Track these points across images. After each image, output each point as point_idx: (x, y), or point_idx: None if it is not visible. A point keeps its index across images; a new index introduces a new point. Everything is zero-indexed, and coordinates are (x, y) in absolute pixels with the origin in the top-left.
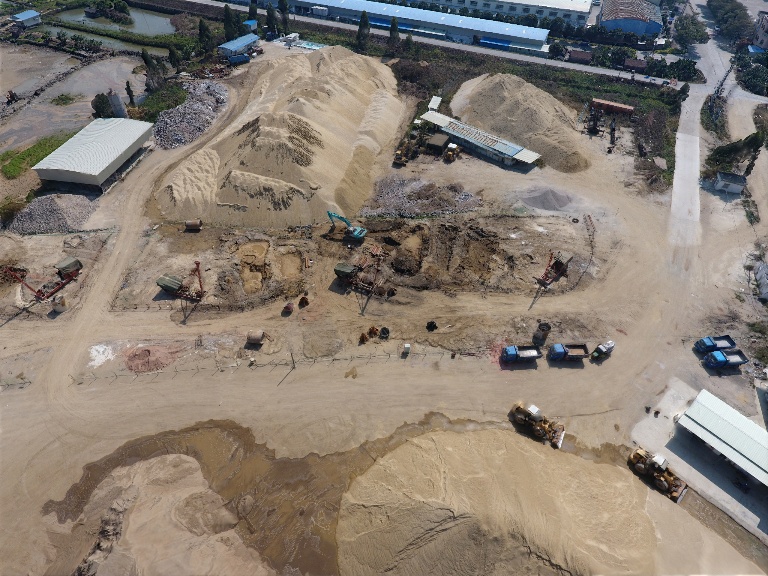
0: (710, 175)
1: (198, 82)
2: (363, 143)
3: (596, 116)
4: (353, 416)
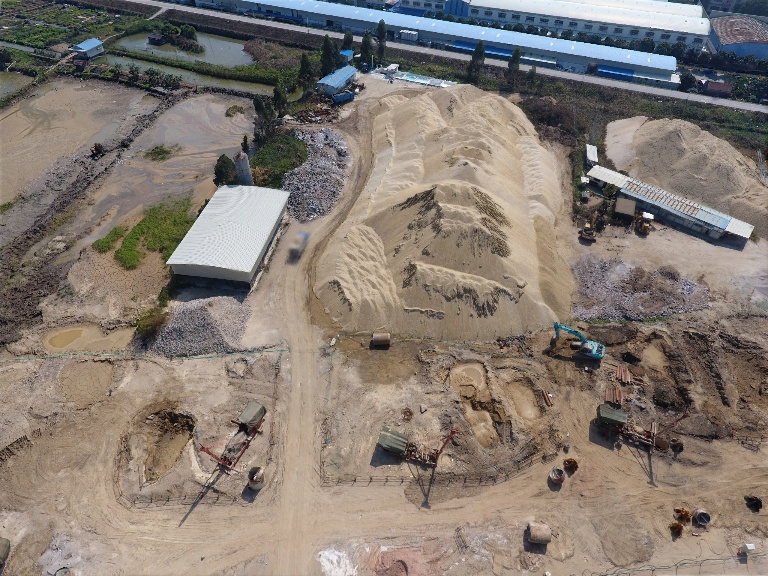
0: None
1: (314, 130)
2: (538, 212)
3: None
4: None
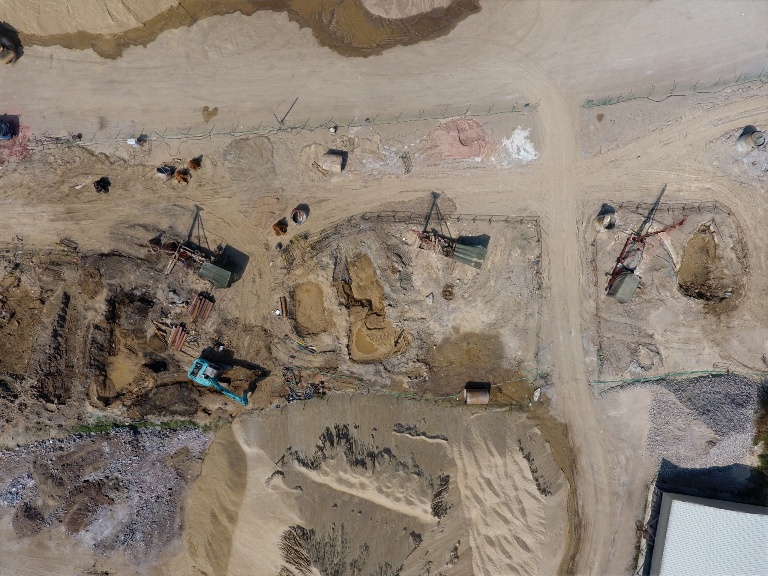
0: None
1: None
2: None
3: None
4: (206, 56)
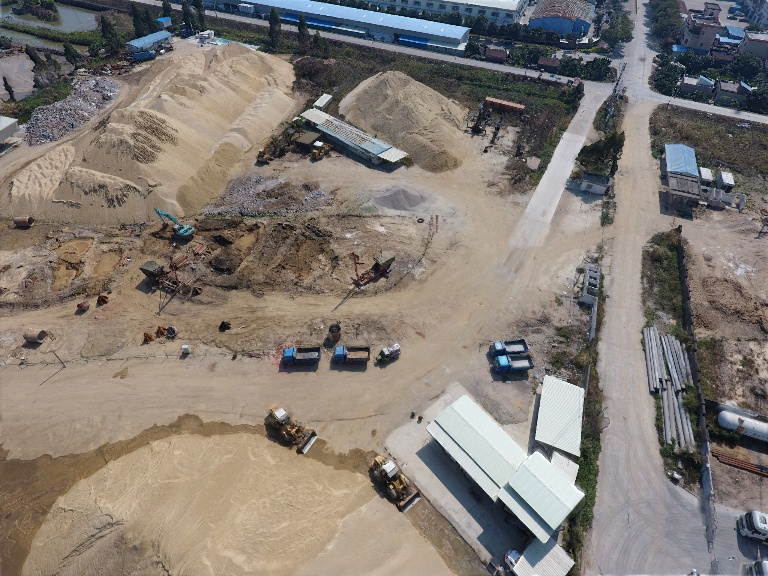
0: (580, 175)
1: (87, 78)
2: (230, 140)
3: (481, 115)
4: (104, 417)
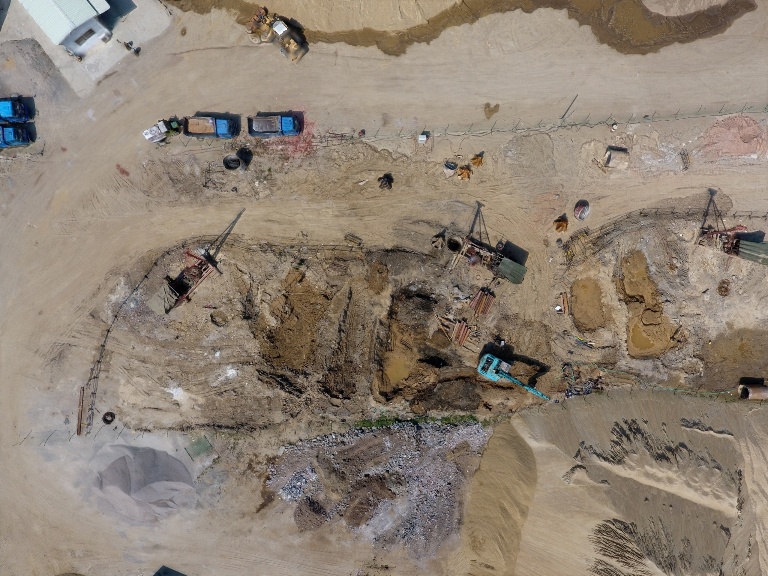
0: None
1: None
2: None
3: None
4: (488, 53)
